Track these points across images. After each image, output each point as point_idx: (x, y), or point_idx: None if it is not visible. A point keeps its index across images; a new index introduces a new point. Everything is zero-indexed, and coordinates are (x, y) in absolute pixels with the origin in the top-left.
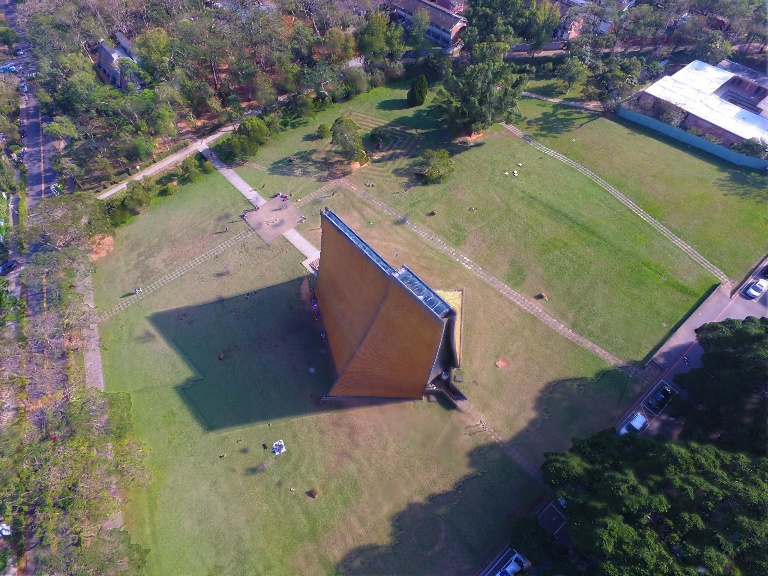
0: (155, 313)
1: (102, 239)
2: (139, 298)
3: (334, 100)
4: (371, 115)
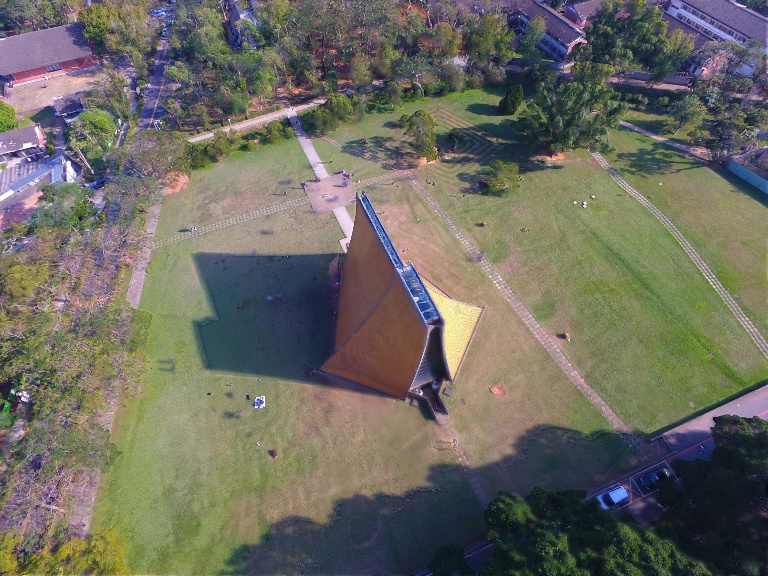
0: (200, 252)
1: (178, 176)
2: (192, 236)
3: (426, 93)
4: (457, 115)
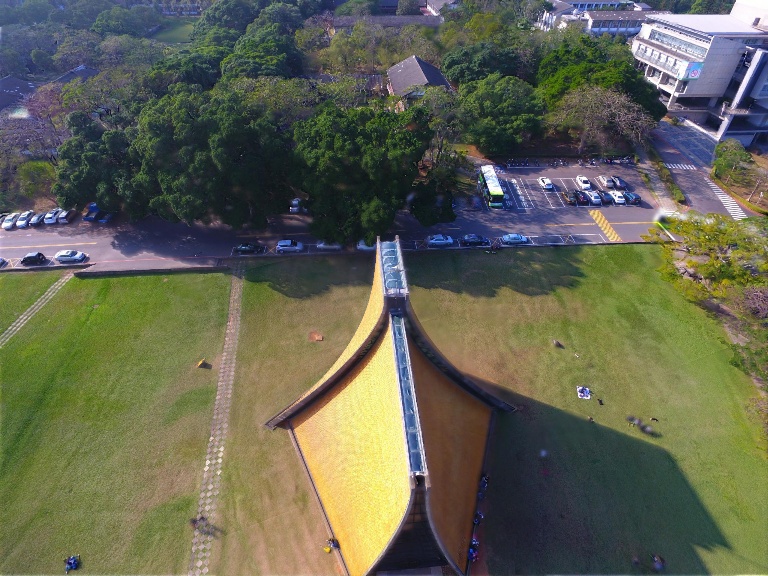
0: None
1: None
2: None
3: None
4: None
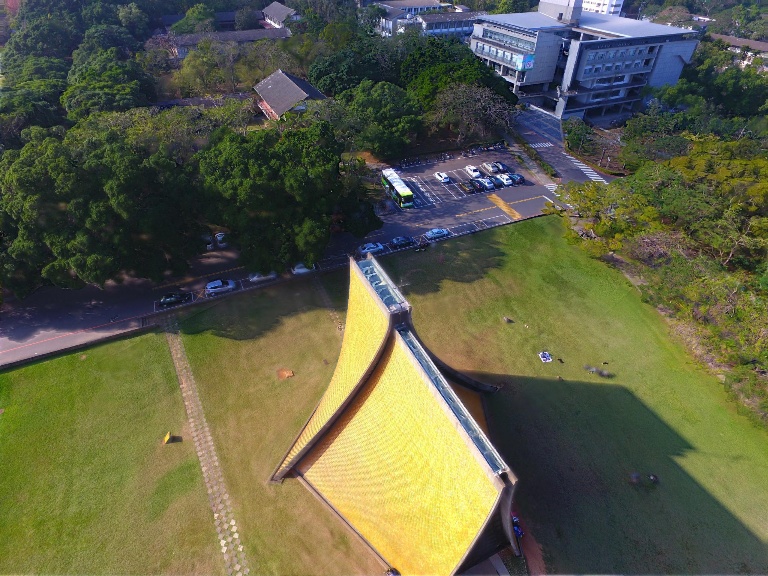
0: None
1: None
2: None
3: None
4: None
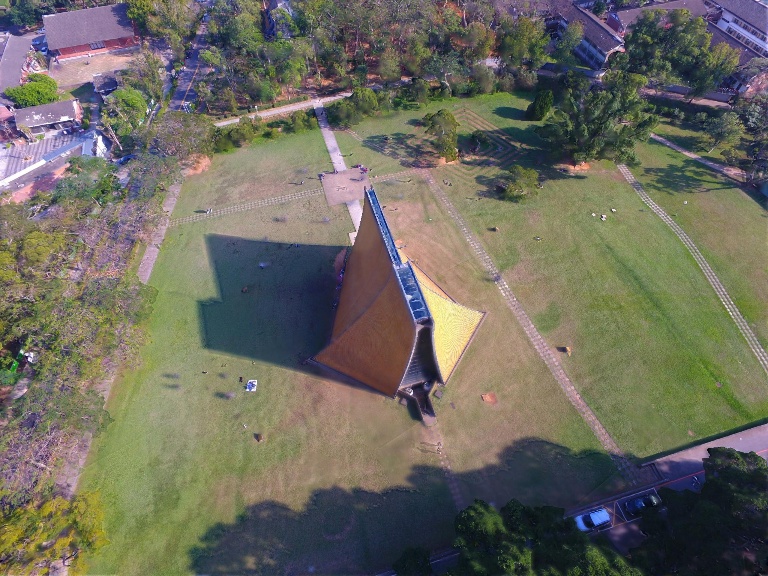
0: (213, 234)
1: (199, 158)
2: (207, 217)
3: (454, 93)
4: (483, 117)
